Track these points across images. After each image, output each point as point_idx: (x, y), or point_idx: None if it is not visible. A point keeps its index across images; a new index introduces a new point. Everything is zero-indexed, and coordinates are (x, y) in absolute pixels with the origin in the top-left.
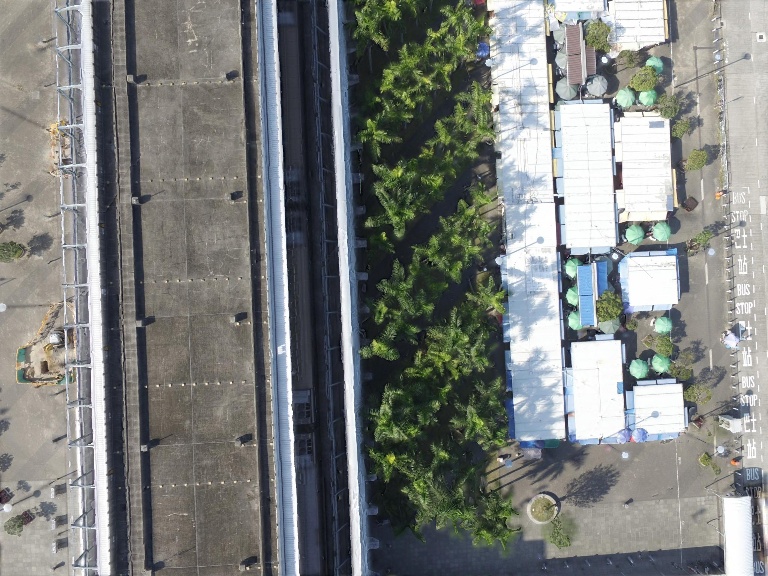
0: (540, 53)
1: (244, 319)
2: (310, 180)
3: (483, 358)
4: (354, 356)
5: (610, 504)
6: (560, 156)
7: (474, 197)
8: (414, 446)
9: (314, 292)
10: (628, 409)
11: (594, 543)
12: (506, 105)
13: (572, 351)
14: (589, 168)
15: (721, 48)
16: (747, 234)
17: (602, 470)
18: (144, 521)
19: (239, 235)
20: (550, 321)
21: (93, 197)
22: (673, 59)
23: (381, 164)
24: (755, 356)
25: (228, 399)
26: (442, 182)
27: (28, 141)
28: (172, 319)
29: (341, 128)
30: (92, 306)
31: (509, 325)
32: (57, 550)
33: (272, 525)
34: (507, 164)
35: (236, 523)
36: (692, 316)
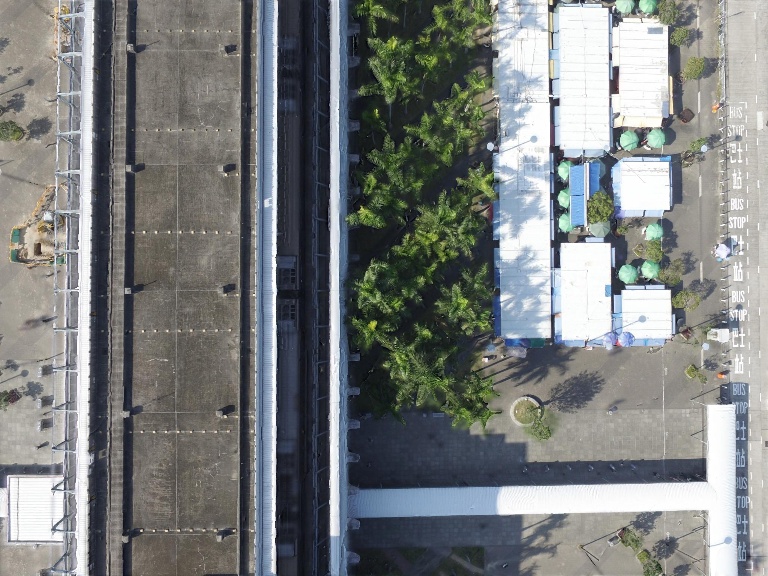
0: None
1: (232, 170)
2: (306, 56)
3: (470, 236)
4: (341, 222)
5: (594, 411)
6: (557, 58)
7: (468, 81)
8: (397, 320)
9: (305, 166)
10: (615, 313)
11: (576, 449)
12: (505, 4)
13: (561, 252)
14: (586, 71)
15: None
16: (743, 149)
17: (587, 376)
18: (125, 364)
19: (231, 88)
20: (540, 220)
21: (89, 45)
22: None
23: (376, 38)
24: (746, 271)
25: (213, 249)
26: (436, 62)
27: (32, 26)
28: (161, 167)
29: None
30: (83, 152)
31: (499, 222)
32: (42, 429)
33: (251, 375)
34: (504, 63)
35: (216, 371)
36: (684, 228)
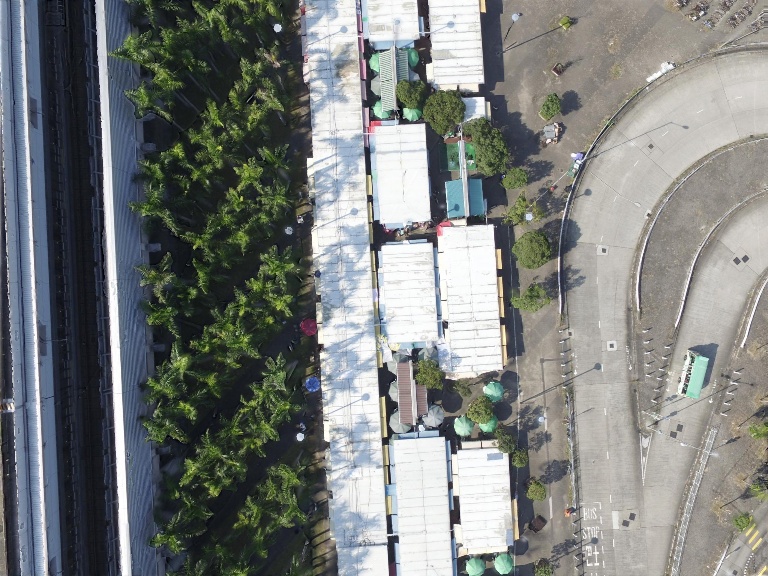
0: (372, 388)
1: None
2: None
3: None
4: None
5: None
6: (394, 493)
7: None
8: None
9: None
10: None
11: None
12: (337, 443)
13: None
14: (424, 505)
15: (569, 359)
16: (599, 551)
17: None
18: None
19: None
20: None
21: None
22: (519, 373)
23: (175, 574)
24: None
25: None
26: (246, 575)
27: None
28: None
29: (128, 547)
30: None
31: None
32: None
33: None
34: (338, 505)
35: None
36: None
